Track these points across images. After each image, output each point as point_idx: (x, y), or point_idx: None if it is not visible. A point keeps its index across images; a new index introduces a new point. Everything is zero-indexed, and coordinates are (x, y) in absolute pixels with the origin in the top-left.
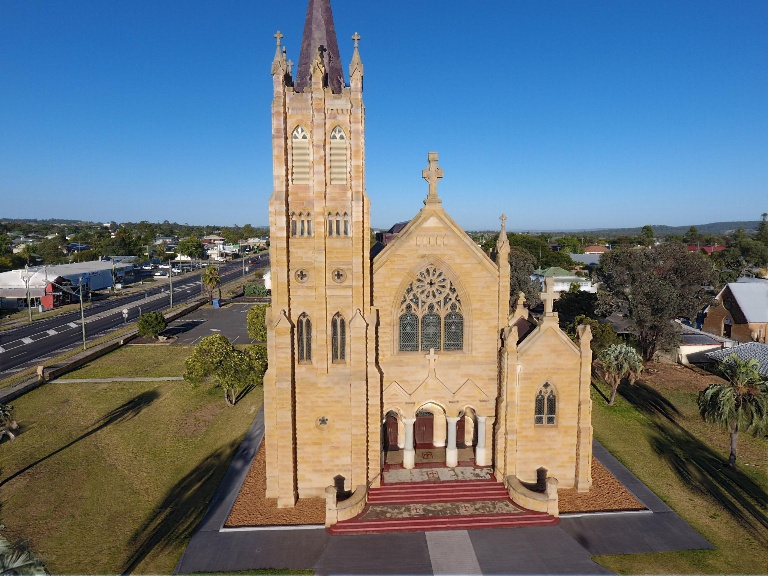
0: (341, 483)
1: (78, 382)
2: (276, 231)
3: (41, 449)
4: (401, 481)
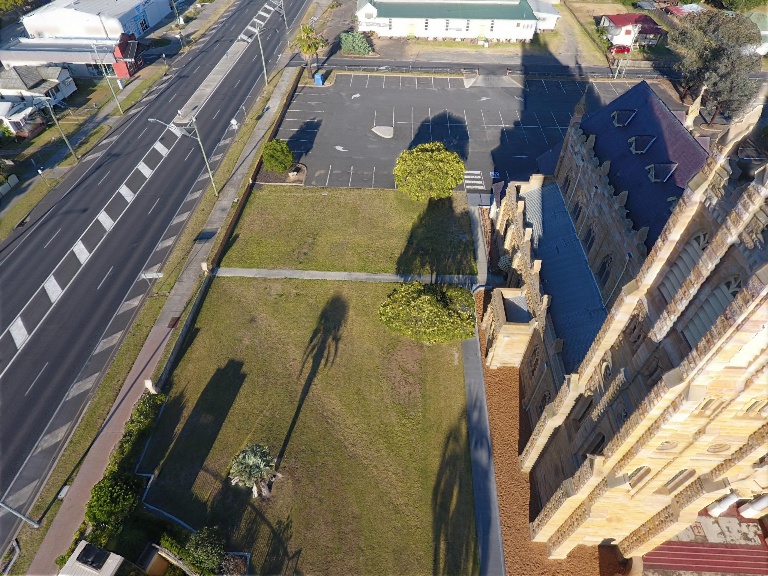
0: (610, 541)
1: (245, 276)
2: (665, 425)
3: (275, 421)
4: (668, 539)
